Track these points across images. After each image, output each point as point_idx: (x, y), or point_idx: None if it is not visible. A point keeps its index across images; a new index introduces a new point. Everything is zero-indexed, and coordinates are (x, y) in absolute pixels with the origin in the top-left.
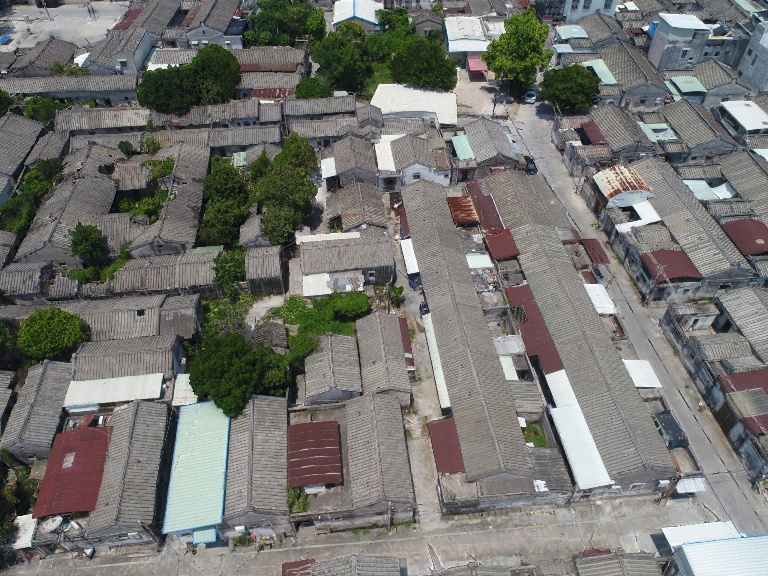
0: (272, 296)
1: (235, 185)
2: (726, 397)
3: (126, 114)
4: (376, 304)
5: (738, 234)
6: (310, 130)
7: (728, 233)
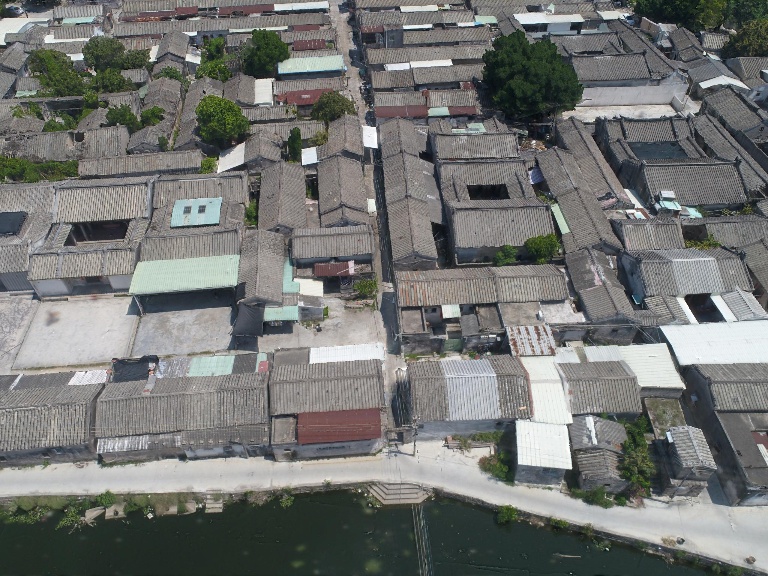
0: None
1: None
2: None
3: None
4: None
5: None
6: (15, 61)
7: None
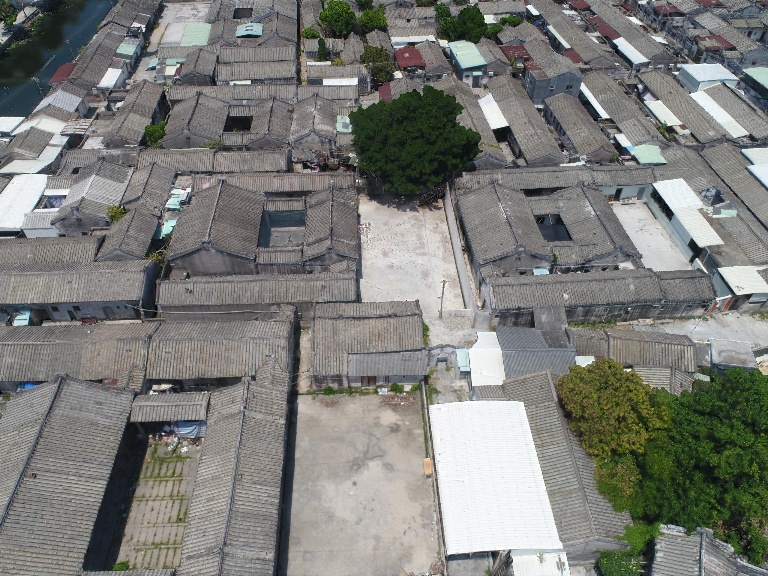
0: None
1: None
2: (698, 45)
3: None
4: None
5: (703, 1)
6: None
7: (698, 2)
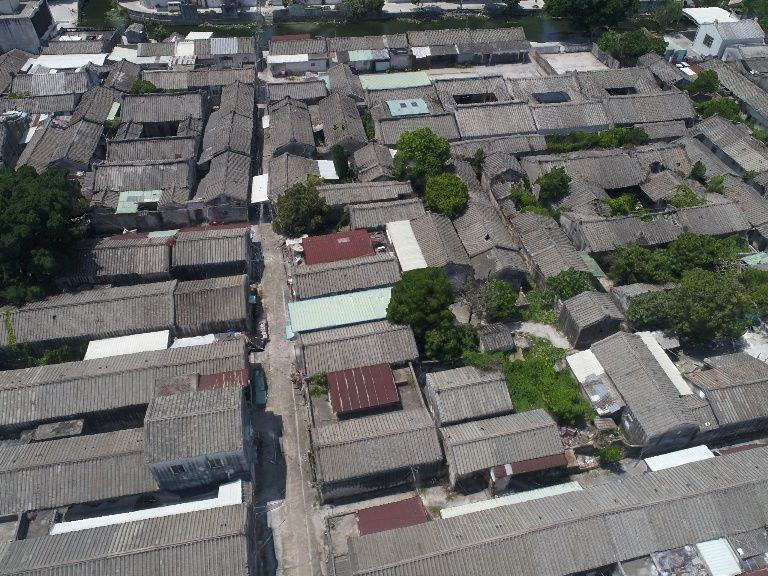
0: (566, 338)
1: (696, 259)
2: None
3: (753, 155)
4: (588, 435)
5: None
6: None
7: None
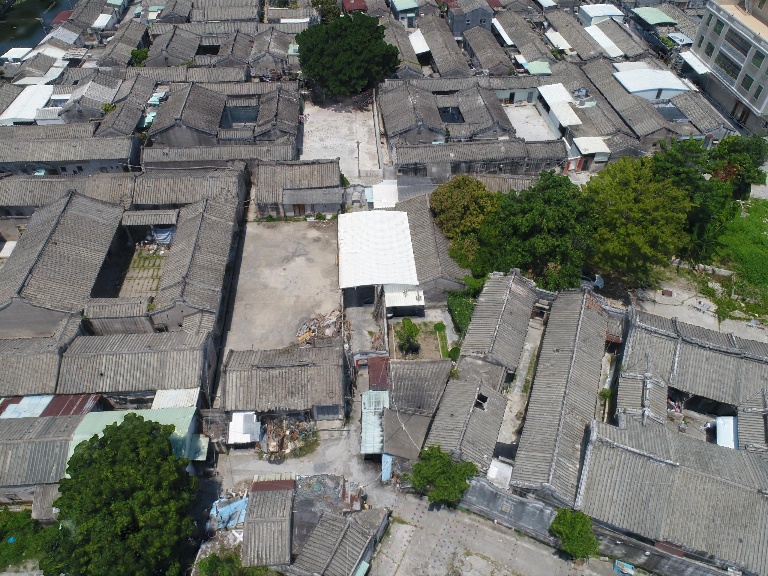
0: None
1: None
2: None
3: None
4: None
5: None
6: None
7: None
